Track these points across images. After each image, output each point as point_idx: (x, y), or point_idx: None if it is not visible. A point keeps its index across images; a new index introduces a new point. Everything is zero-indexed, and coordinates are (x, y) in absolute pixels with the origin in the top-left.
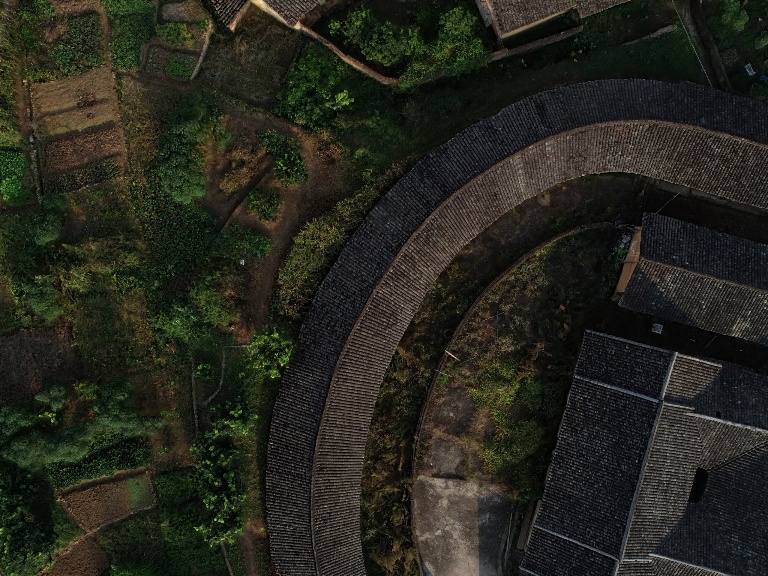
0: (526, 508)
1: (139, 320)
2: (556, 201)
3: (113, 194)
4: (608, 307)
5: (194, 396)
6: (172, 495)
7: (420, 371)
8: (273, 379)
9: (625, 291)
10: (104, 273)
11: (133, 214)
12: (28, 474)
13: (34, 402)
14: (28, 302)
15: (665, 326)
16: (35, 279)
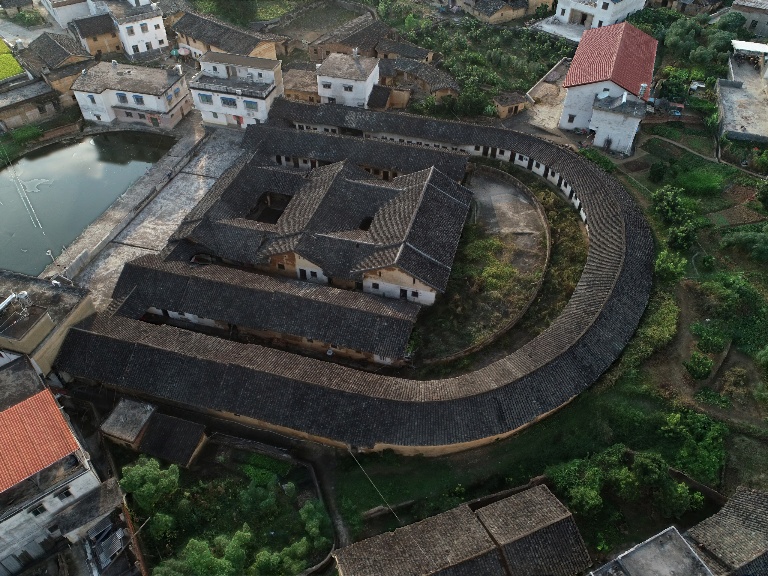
0: None
1: (765, 294)
2: None
3: None
4: None
5: None
6: None
7: None
8: None
9: None
10: None
11: None
12: None
13: None
14: None
15: None
16: None
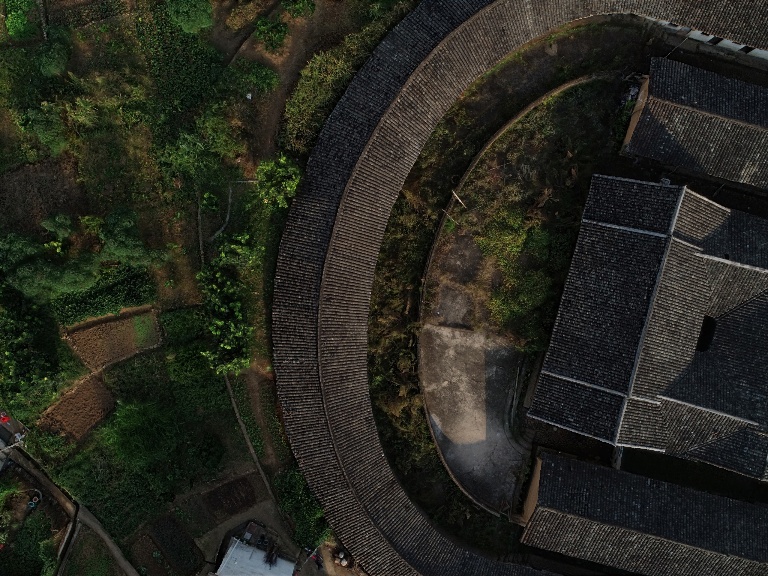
0: (533, 366)
1: (145, 156)
2: (563, 51)
3: (119, 30)
4: (615, 163)
5: (200, 231)
6: (178, 333)
7: (427, 214)
8: (280, 215)
9: (633, 134)
10: (110, 108)
11: (139, 50)
12: (33, 305)
13: (39, 236)
14: (34, 130)
15: (673, 181)
16: (41, 105)
